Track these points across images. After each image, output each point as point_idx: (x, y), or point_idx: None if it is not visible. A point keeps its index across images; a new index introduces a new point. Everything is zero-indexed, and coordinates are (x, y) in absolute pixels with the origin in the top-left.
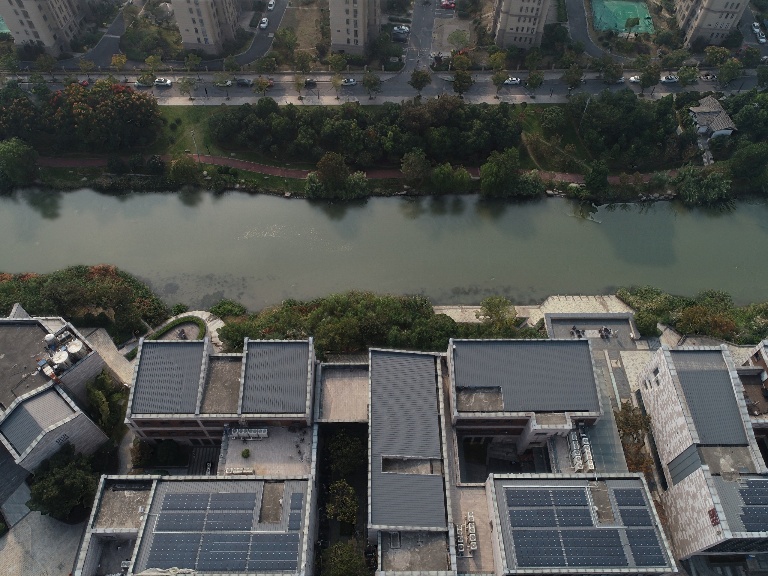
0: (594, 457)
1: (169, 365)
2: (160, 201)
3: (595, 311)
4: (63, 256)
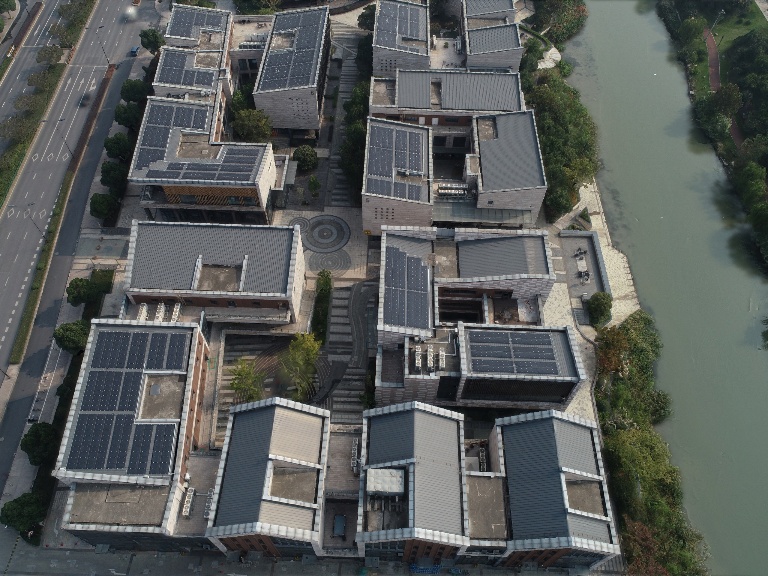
0: (450, 202)
1: (496, 1)
2: (658, 32)
3: (615, 288)
4: (593, 0)
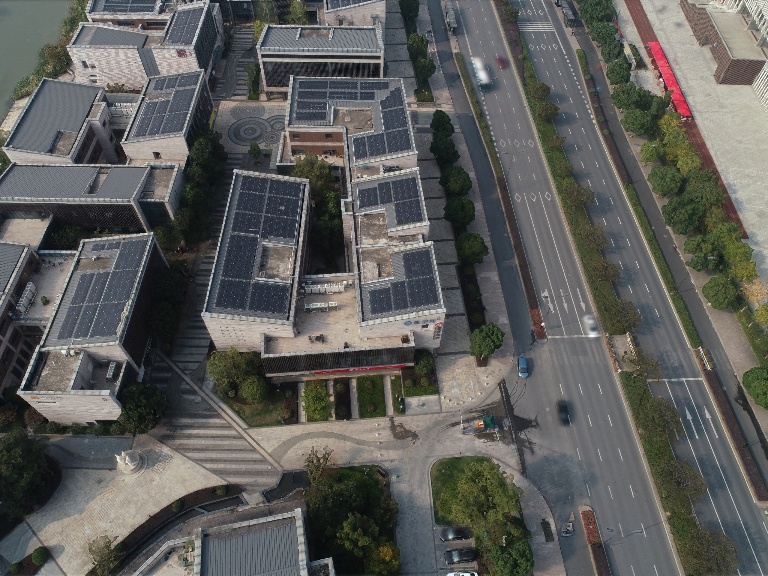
0: None
1: None
2: None
3: None
4: None
